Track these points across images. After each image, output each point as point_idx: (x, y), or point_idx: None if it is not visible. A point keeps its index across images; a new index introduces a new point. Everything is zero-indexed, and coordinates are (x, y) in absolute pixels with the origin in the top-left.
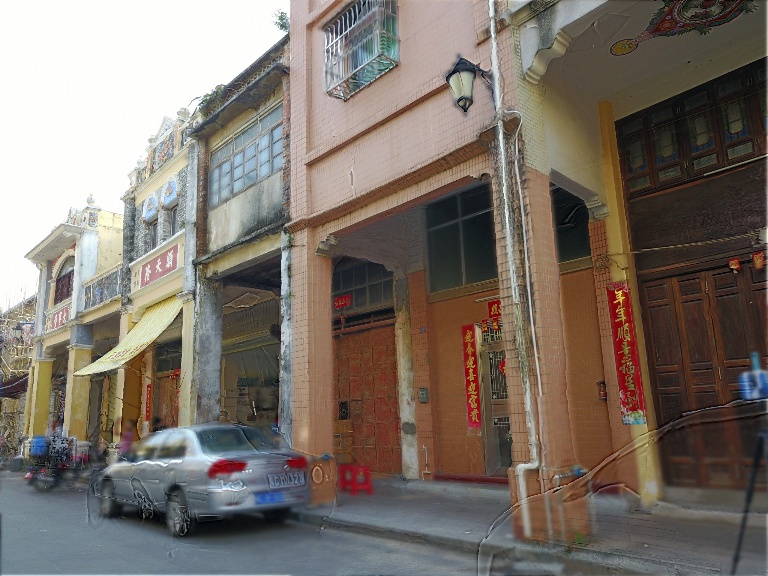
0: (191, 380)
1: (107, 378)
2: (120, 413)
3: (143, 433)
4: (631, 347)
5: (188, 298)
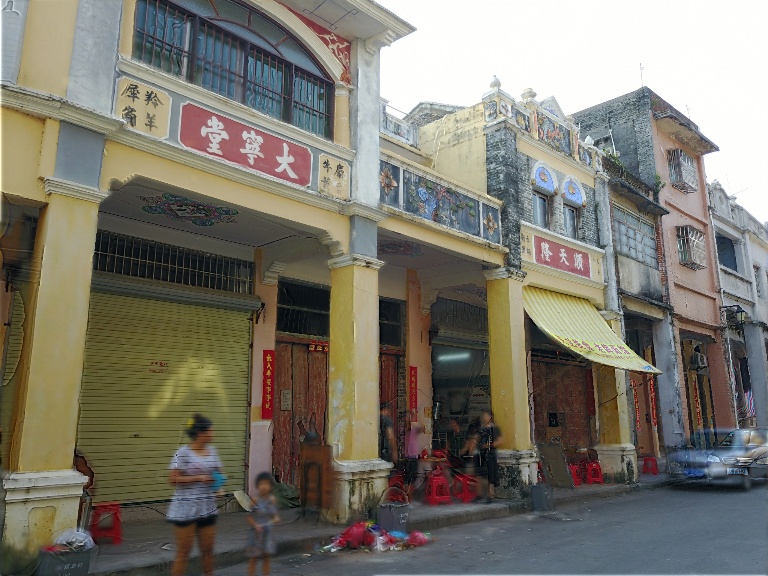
0: (626, 390)
1: (3, 285)
2: (527, 411)
3: (257, 444)
4: (654, 402)
5: (617, 318)
